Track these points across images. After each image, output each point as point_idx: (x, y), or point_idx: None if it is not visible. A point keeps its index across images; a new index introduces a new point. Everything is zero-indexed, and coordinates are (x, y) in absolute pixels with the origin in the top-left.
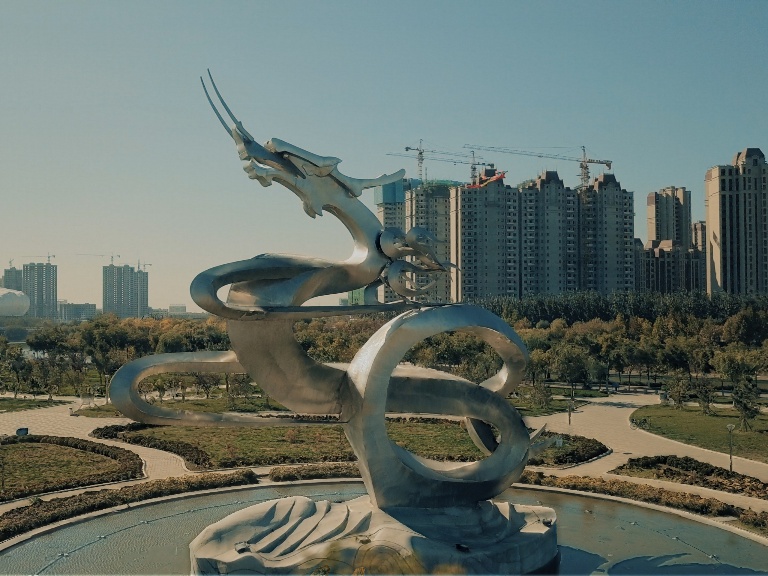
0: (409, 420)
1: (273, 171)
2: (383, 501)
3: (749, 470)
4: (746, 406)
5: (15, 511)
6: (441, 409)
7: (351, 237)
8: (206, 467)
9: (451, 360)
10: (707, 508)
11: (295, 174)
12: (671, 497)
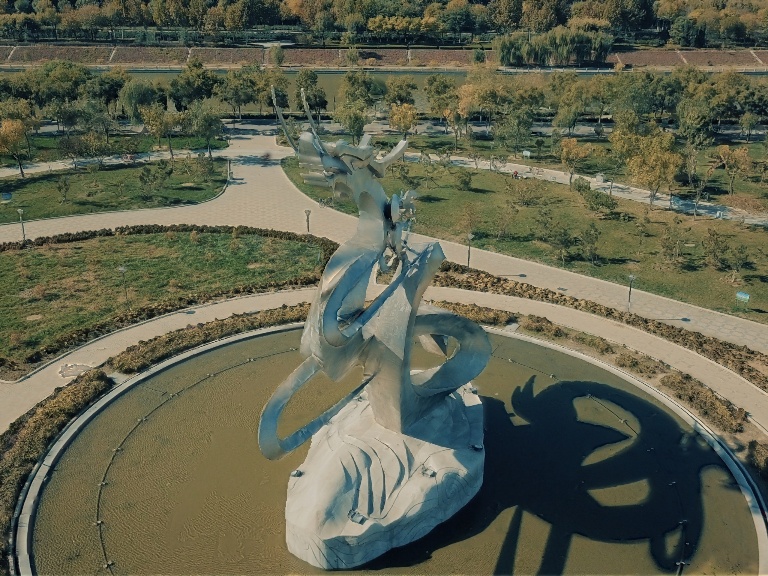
0: (118, 232)
1: (336, 177)
2: (402, 426)
3: (463, 257)
4: (412, 181)
5: None
6: (414, 333)
7: (359, 208)
8: (15, 370)
9: (65, 122)
10: (497, 320)
11: (346, 172)
12: (468, 314)
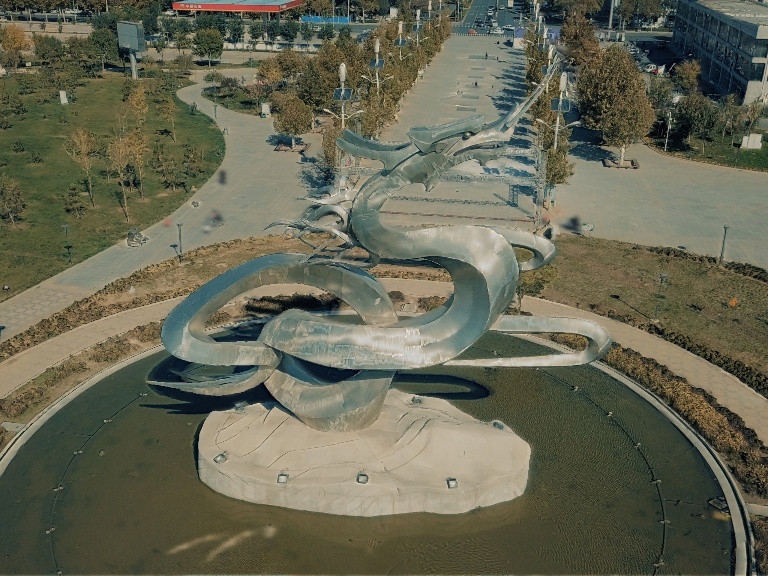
0: None
1: None
2: None
3: None
4: None
5: None
6: None
7: None
8: None
9: None
10: None
11: None
12: None
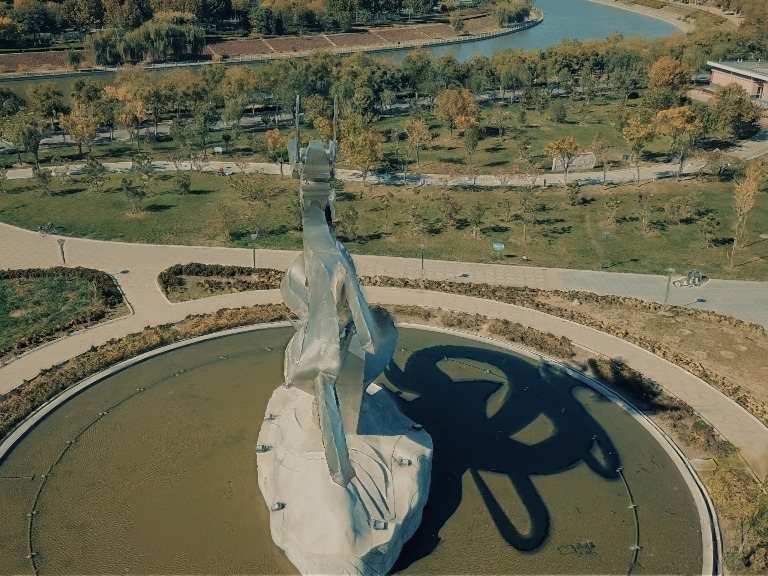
0: None
1: None
2: None
3: (236, 259)
4: None
5: None
6: None
7: (303, 215)
8: None
9: None
10: None
11: None
12: None
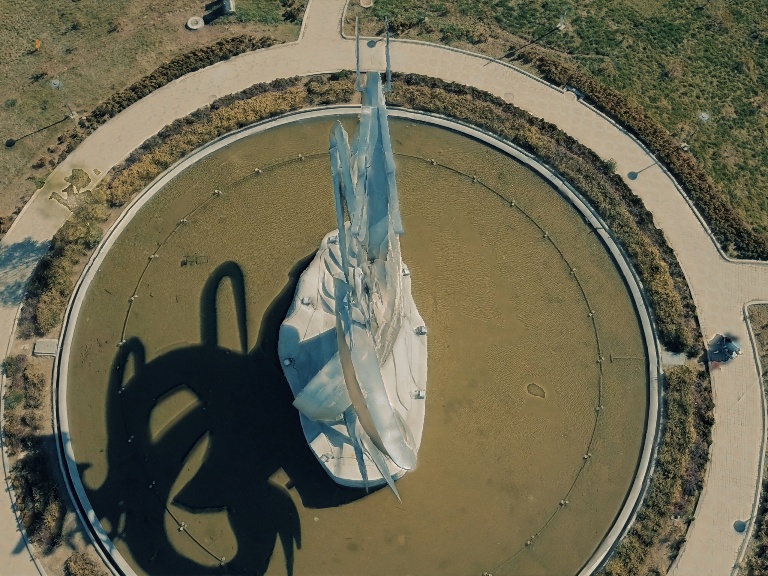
0: None
1: None
2: None
3: None
4: None
5: (584, 151)
6: None
7: None
8: None
9: None
10: None
11: None
12: None
